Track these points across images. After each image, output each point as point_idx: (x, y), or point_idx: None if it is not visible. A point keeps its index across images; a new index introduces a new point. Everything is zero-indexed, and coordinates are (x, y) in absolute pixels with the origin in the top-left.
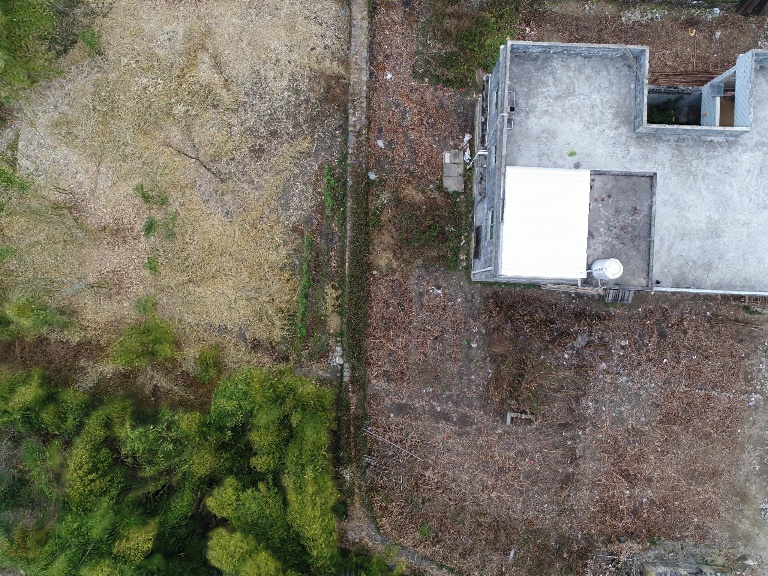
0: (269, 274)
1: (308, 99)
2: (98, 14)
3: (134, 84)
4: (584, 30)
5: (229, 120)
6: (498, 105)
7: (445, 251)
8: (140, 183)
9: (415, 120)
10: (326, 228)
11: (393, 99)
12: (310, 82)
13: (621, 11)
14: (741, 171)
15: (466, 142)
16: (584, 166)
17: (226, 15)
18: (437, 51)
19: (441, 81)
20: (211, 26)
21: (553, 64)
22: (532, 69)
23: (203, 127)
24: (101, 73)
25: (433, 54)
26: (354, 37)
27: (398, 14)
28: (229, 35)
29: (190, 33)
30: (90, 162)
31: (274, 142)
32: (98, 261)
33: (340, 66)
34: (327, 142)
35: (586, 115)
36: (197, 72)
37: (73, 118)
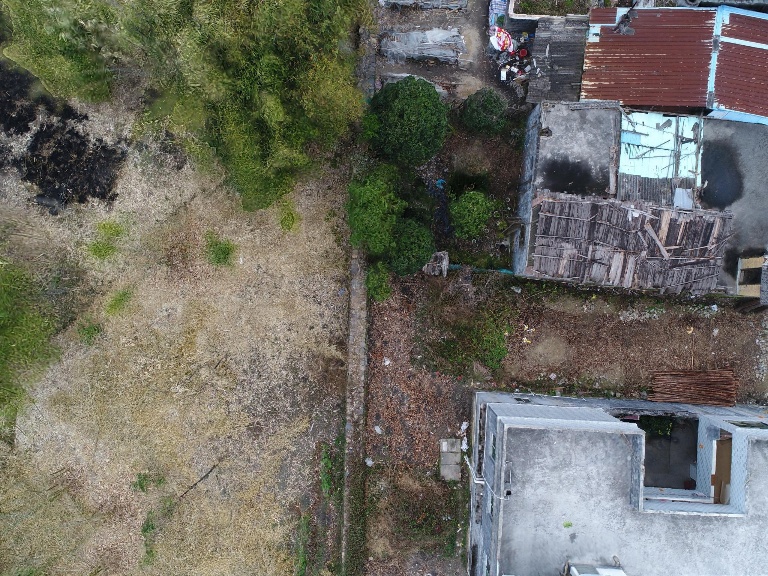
0: (265, 556)
1: (306, 378)
2: (97, 292)
3: (133, 362)
4: (582, 328)
5: (227, 398)
6: (495, 475)
7: (441, 540)
8: (138, 460)
9: (413, 407)
10: (323, 508)
11: (391, 385)
12: (308, 361)
13: (619, 311)
14: (736, 544)
15: (463, 431)
16: (580, 537)
17: (225, 293)
18: (435, 338)
19: (439, 371)
20: (210, 304)
21: (550, 435)
22: (529, 439)
23: (201, 405)
24: (100, 349)
25: (431, 341)
26: (352, 327)
27: (397, 300)
28: (228, 313)
29: (189, 313)
30: (88, 438)
31: (272, 420)
32: (95, 538)
33: (338, 351)
34: (325, 421)
35: (582, 486)
36: (196, 350)
37: (71, 394)
